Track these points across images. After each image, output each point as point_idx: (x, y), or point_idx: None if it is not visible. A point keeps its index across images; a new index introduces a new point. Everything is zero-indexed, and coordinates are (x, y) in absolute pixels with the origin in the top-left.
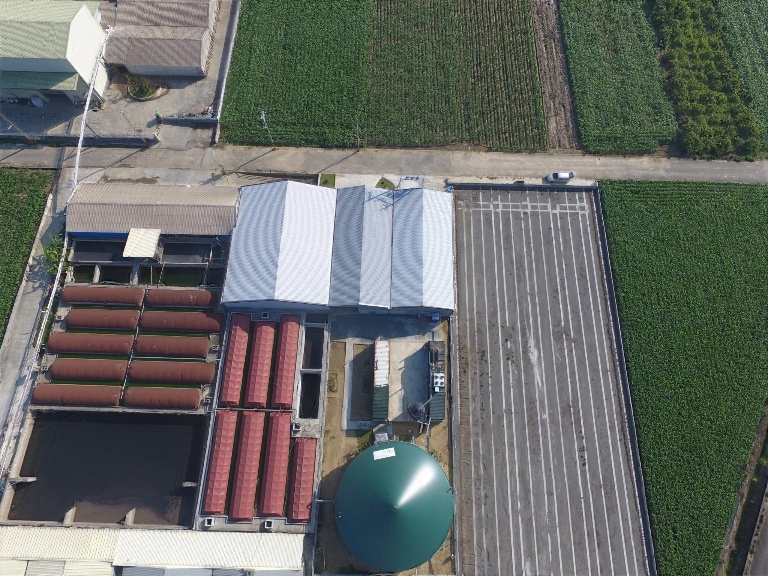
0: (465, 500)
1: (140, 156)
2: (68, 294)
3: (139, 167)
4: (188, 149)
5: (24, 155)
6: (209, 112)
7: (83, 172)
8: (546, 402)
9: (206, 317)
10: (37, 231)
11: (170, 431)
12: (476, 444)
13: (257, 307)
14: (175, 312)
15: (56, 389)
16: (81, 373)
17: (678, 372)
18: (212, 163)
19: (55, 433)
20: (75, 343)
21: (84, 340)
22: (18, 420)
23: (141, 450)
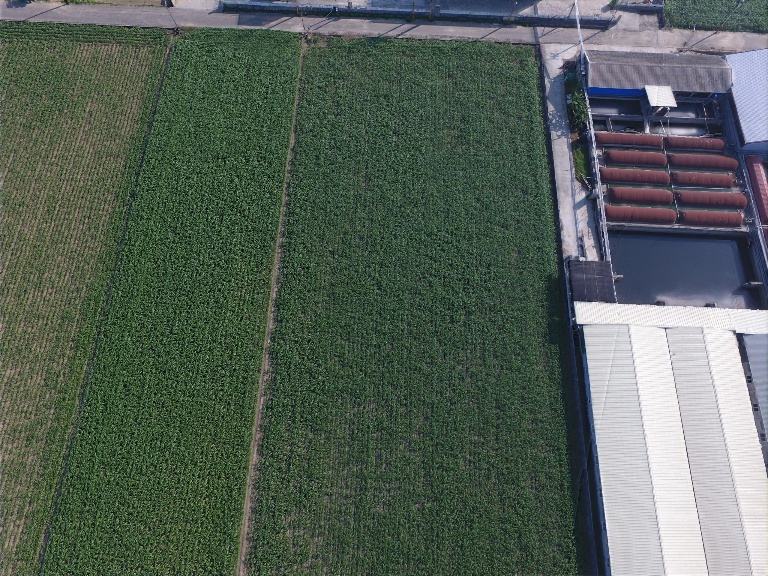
0: None
1: (603, 35)
2: (605, 137)
3: (606, 44)
4: (642, 31)
5: (503, 32)
6: (649, 1)
7: (559, 47)
8: None
9: (726, 157)
10: (542, 92)
11: (713, 247)
12: None
13: (766, 150)
14: (693, 154)
15: (625, 208)
16: (640, 197)
17: None
18: (667, 42)
19: (616, 247)
20: (626, 174)
21: (633, 172)
22: (589, 234)
23: (693, 261)
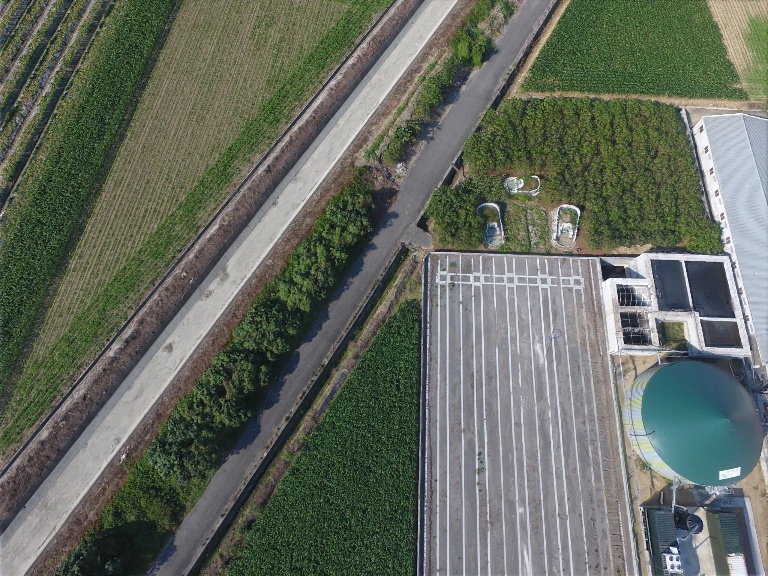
0: (605, 420)
1: None
2: None
3: None
4: None
5: None
6: None
7: None
8: (519, 529)
9: None
10: None
11: None
12: (598, 478)
13: None
14: None
15: None
16: None
17: (353, 569)
18: None
19: None
20: None
21: None
22: None
23: None
